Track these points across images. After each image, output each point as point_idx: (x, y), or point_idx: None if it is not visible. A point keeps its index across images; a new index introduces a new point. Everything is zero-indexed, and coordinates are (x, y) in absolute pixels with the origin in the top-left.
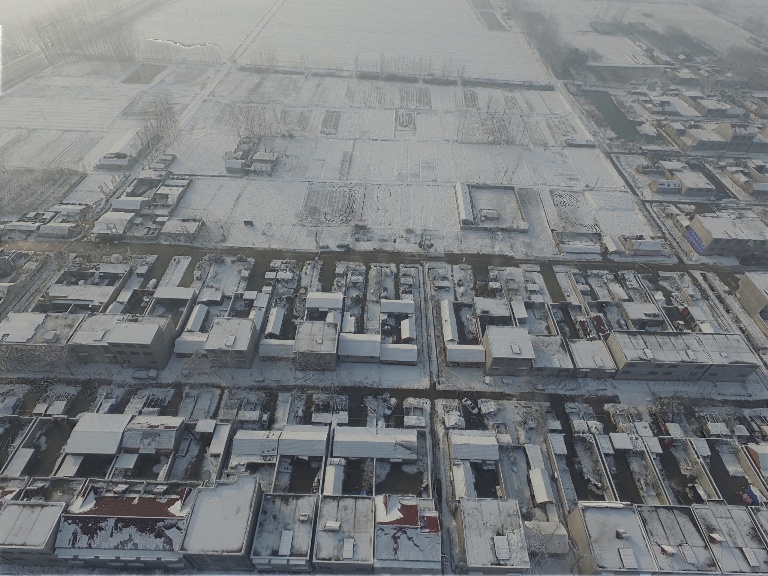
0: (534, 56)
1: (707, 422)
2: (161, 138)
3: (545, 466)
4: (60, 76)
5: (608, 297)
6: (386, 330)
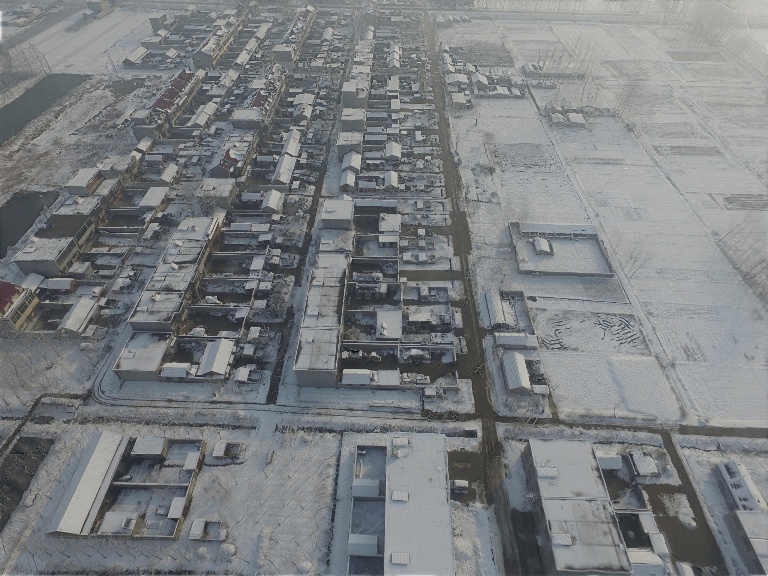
0: None
1: None
2: None
3: None
4: (651, 32)
5: None
6: None
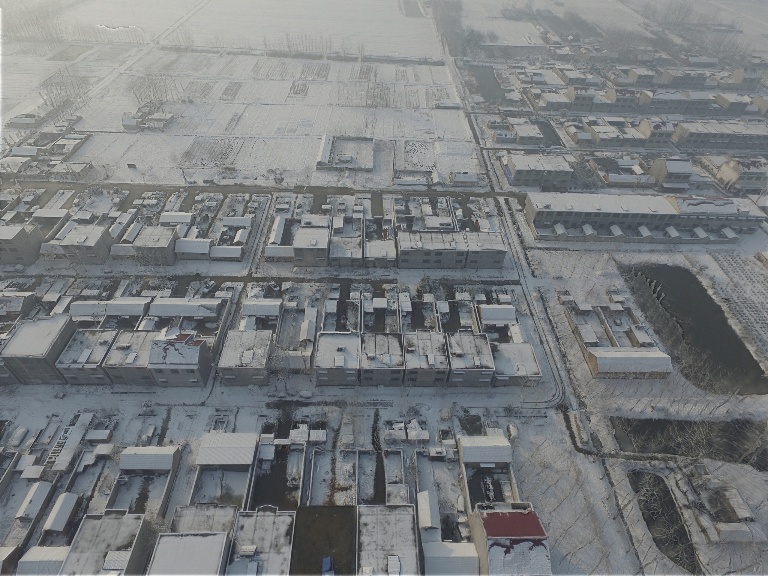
0: (438, 38)
1: (456, 292)
2: (72, 103)
3: (319, 322)
4: None
5: (419, 215)
6: (225, 239)
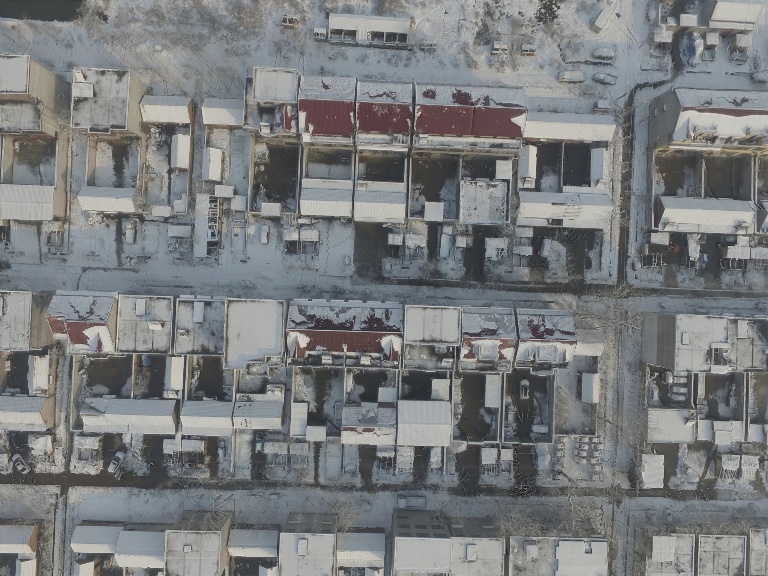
0: None
1: None
2: None
3: None
4: None
5: None
6: None
